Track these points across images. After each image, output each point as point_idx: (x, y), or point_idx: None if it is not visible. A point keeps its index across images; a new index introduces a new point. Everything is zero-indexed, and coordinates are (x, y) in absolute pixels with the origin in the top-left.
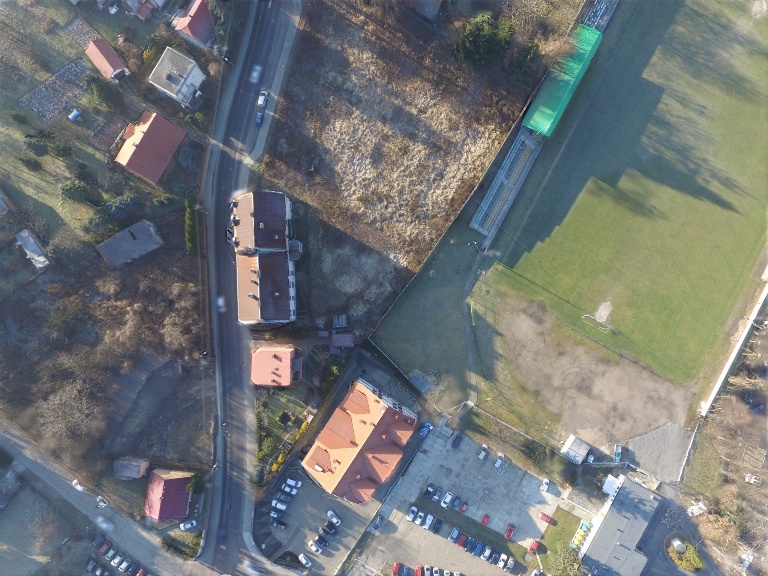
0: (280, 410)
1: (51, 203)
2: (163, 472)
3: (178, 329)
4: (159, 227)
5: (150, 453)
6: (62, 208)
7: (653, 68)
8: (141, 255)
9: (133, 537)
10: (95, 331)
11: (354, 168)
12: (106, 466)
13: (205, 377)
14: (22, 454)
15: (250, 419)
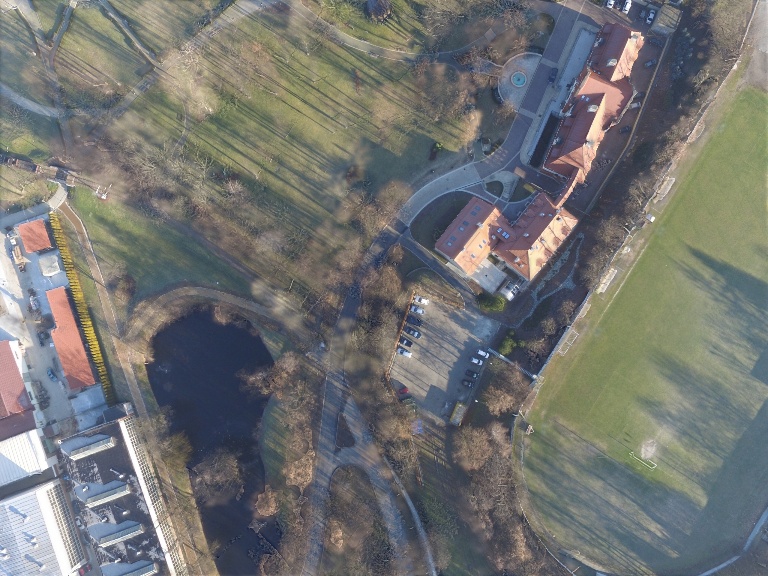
0: None
1: None
2: None
3: None
4: None
5: None
6: None
7: (761, 397)
8: None
9: None
10: None
11: None
12: None
13: None
14: None
15: None
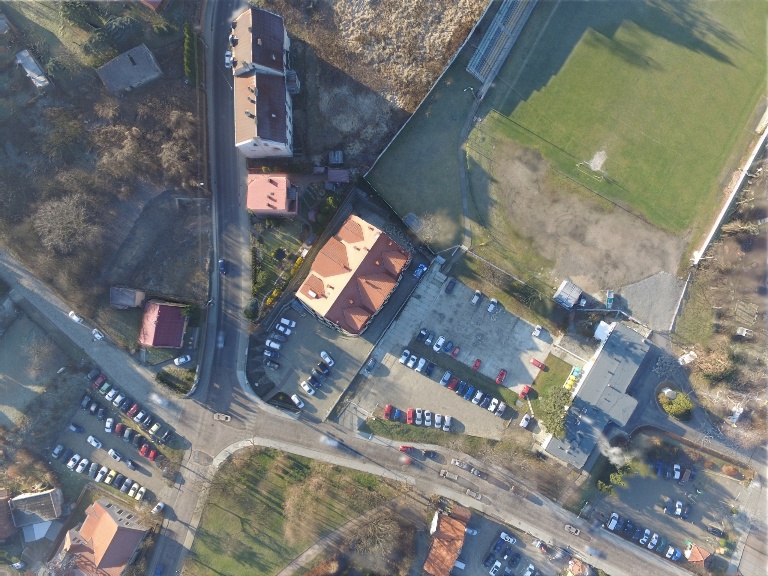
0: (275, 246)
1: (52, 28)
2: (158, 301)
3: (175, 155)
4: (158, 58)
5: (146, 287)
6: (63, 33)
7: None
8: (140, 84)
9: (128, 372)
10: (93, 158)
11: (352, 8)
12: (102, 292)
13: (202, 213)
14: (19, 283)
15: (245, 256)
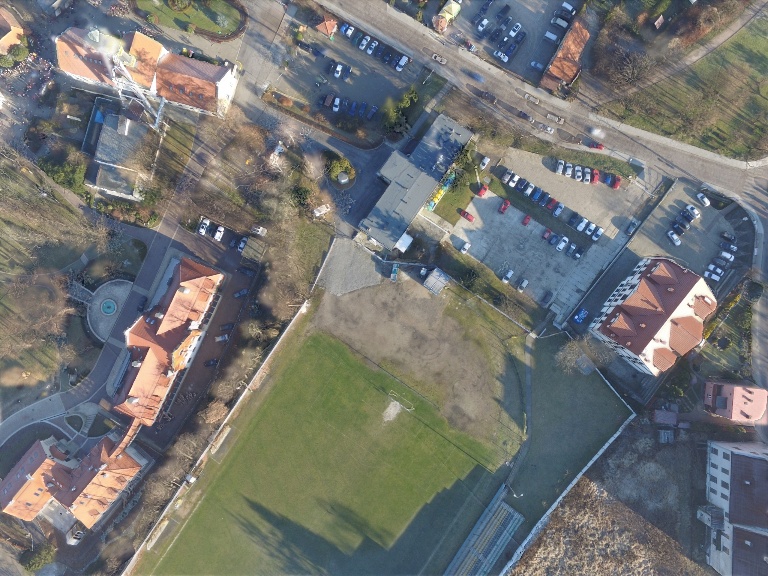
0: (728, 352)
1: None
2: None
3: None
4: None
5: None
6: None
7: None
8: None
9: None
10: None
11: None
12: None
13: None
14: None
15: (755, 345)
